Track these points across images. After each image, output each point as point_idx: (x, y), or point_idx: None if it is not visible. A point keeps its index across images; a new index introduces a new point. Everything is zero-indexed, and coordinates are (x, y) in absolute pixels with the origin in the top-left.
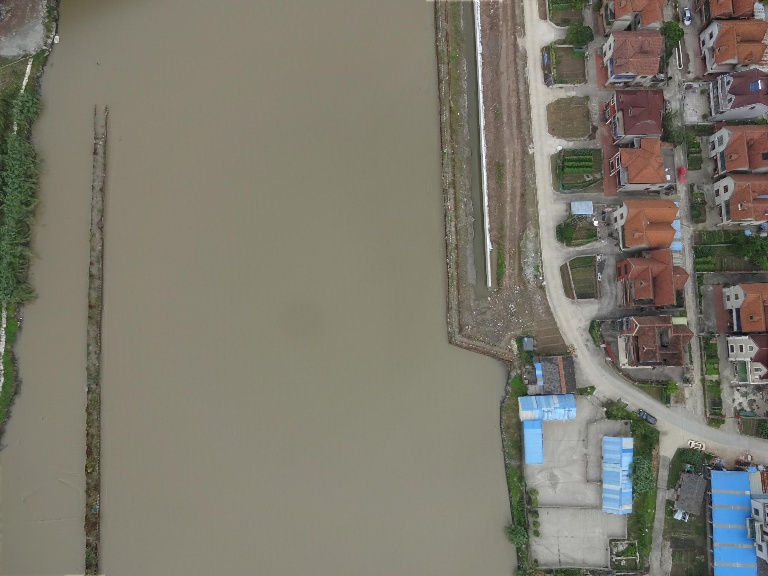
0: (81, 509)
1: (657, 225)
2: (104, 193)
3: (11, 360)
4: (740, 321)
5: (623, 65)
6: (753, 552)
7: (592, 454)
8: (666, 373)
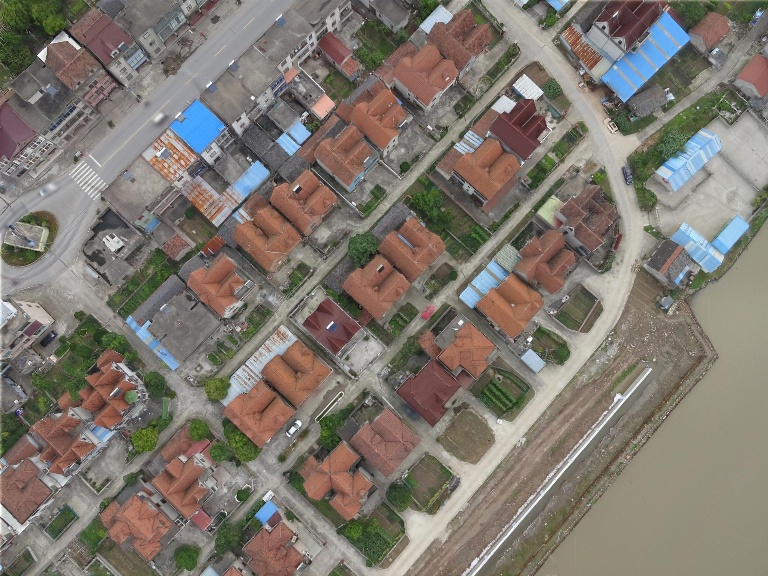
0: None
1: (510, 298)
2: None
3: None
4: None
5: (410, 442)
6: None
7: (688, 188)
8: None
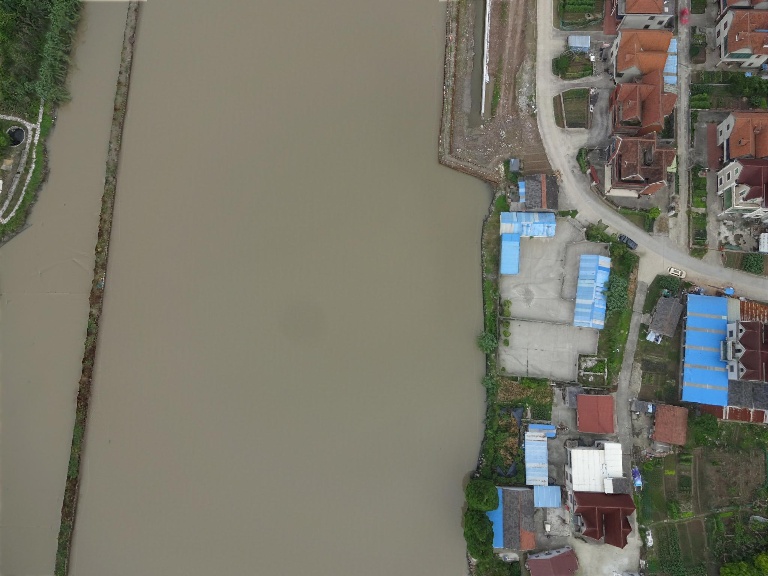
0: (88, 285)
1: (650, 51)
2: (138, 13)
3: (43, 152)
4: (729, 148)
5: None
6: (725, 375)
7: (569, 274)
8: (651, 203)
